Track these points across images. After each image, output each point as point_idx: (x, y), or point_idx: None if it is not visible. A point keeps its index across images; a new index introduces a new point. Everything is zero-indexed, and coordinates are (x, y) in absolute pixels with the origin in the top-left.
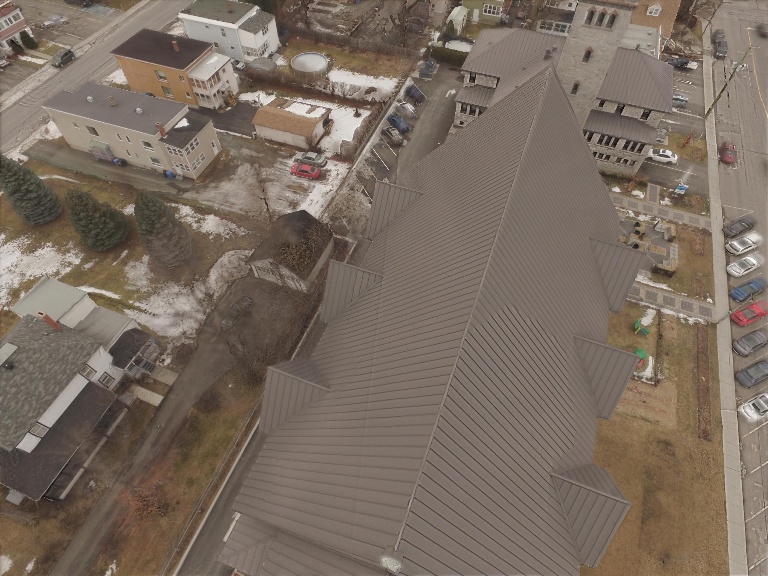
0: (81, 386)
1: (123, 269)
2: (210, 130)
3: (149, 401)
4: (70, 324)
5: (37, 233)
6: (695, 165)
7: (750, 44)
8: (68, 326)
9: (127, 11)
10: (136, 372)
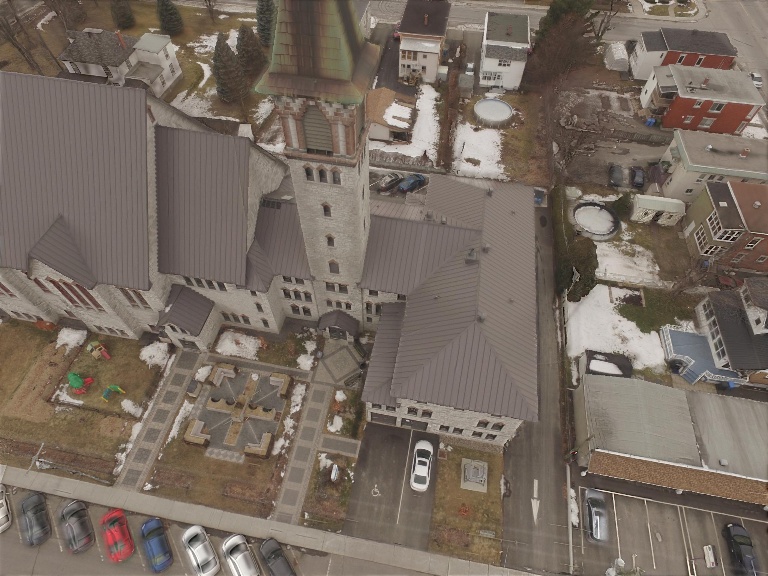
0: (103, 75)
1: None
2: None
3: None
4: (143, 58)
5: None
6: (421, 527)
7: None
8: (141, 58)
9: (526, 5)
10: None
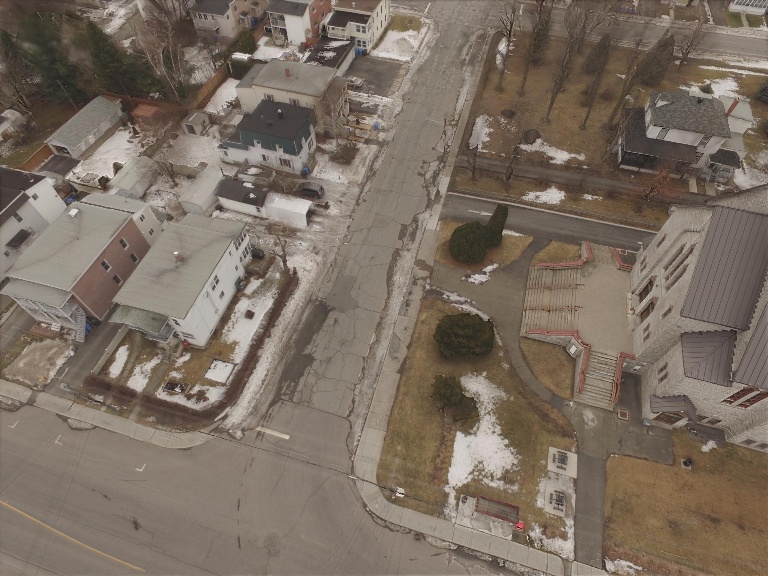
0: (693, 143)
1: (763, 149)
2: None
3: (690, 187)
4: None
5: (753, 101)
6: None
7: None
8: None
9: None
10: (706, 173)
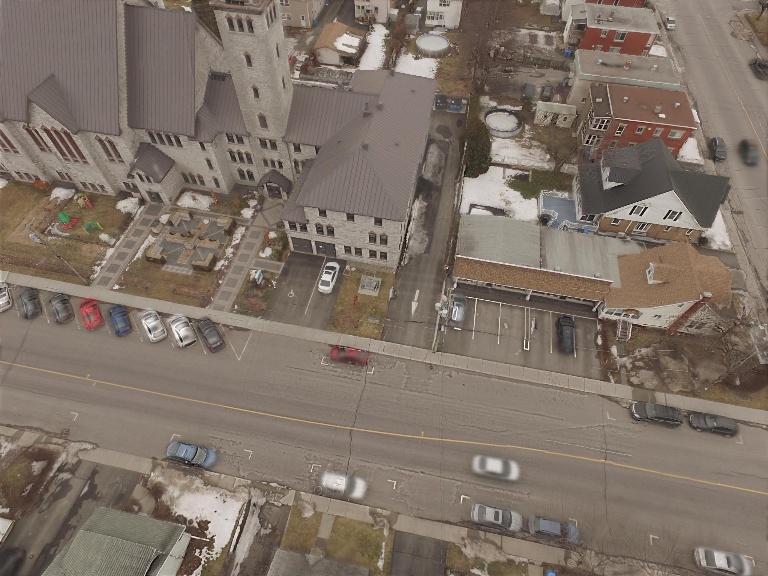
0: None
1: None
2: (304, 7)
3: None
4: None
5: None
6: (323, 315)
7: (723, 483)
8: None
9: None
10: None
